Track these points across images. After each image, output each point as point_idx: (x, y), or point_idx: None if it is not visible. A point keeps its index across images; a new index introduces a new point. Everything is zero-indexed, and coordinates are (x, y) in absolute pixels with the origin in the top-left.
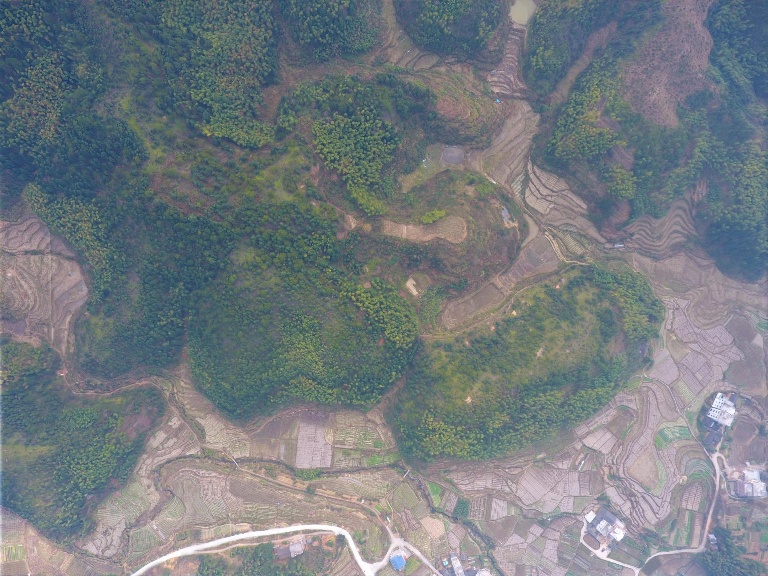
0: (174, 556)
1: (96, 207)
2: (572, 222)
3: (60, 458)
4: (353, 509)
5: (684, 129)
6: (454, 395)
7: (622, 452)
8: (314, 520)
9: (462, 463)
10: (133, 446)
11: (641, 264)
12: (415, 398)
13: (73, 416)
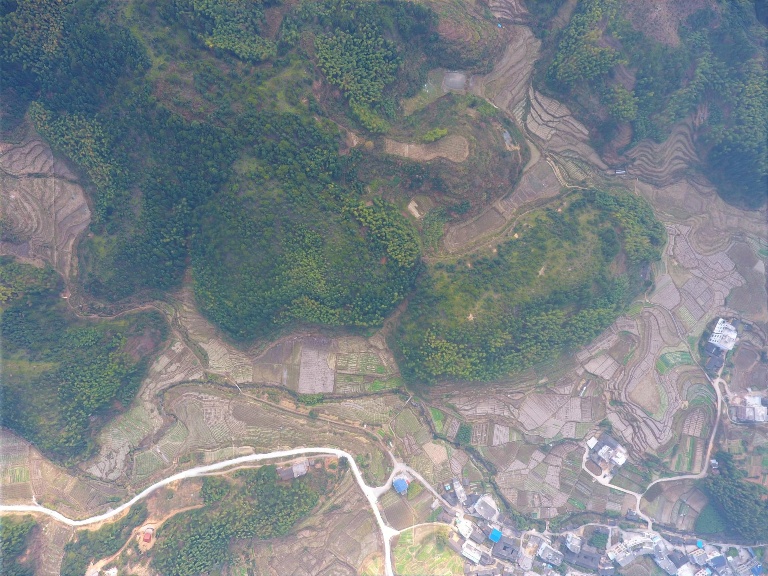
0: (178, 478)
1: (99, 122)
2: (574, 148)
3: (64, 374)
4: (356, 434)
5: (685, 49)
6: (456, 313)
7: (624, 377)
8: (317, 443)
9: (464, 387)
10: (136, 368)
11: (643, 191)
12: (417, 319)
13: (77, 335)
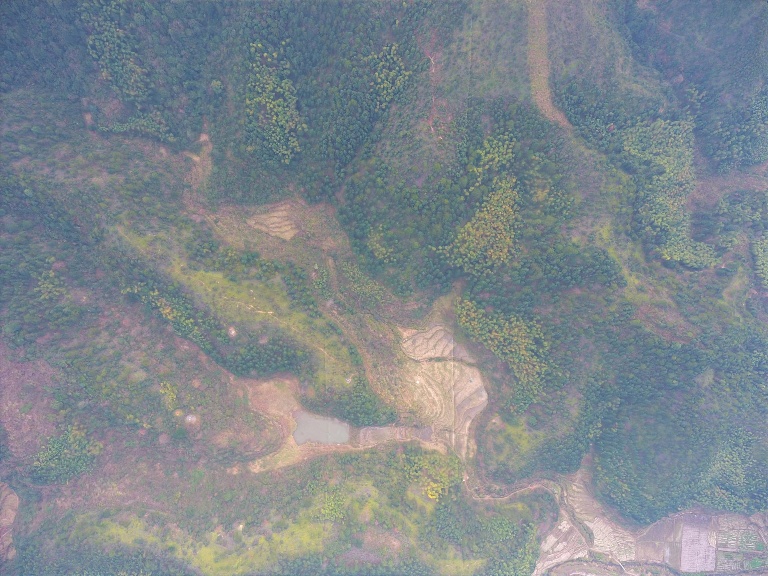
0: None
1: (538, 324)
2: None
3: (493, 571)
4: None
5: None
6: None
7: None
8: None
9: None
10: None
11: None
12: None
13: (493, 526)
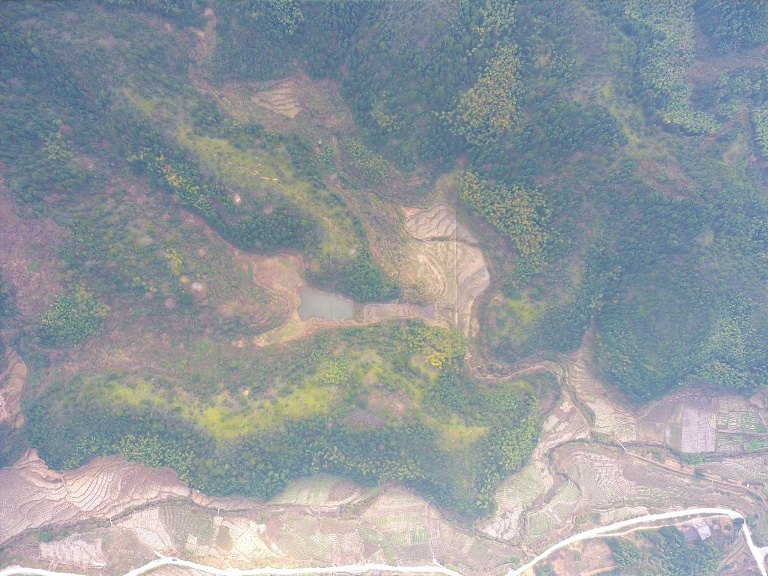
0: (577, 539)
1: (540, 193)
2: None
3: (495, 439)
4: (739, 493)
5: None
6: None
7: None
8: (709, 504)
9: None
10: None
11: None
12: None
13: (495, 398)
